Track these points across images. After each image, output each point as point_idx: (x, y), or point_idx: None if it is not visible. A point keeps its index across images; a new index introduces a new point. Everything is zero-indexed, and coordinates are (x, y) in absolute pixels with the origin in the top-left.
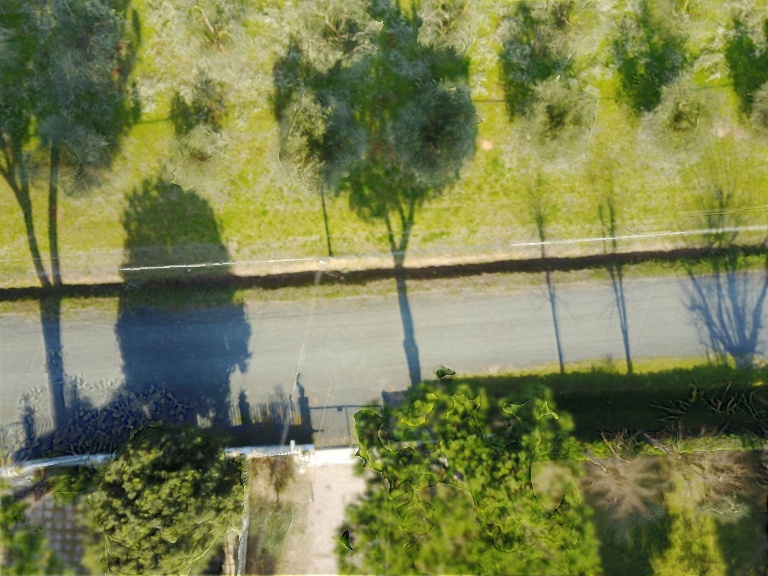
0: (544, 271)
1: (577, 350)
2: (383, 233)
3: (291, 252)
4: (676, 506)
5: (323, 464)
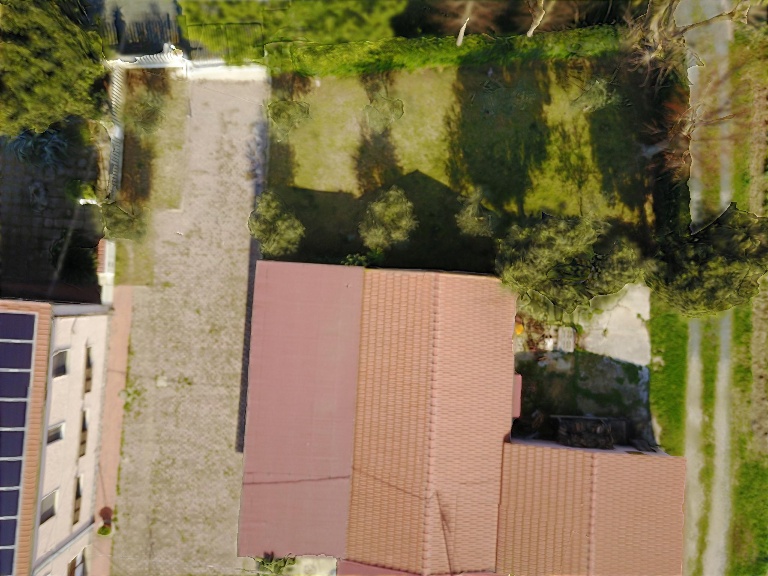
0: None
1: None
2: None
3: None
4: (555, 118)
5: (201, 81)
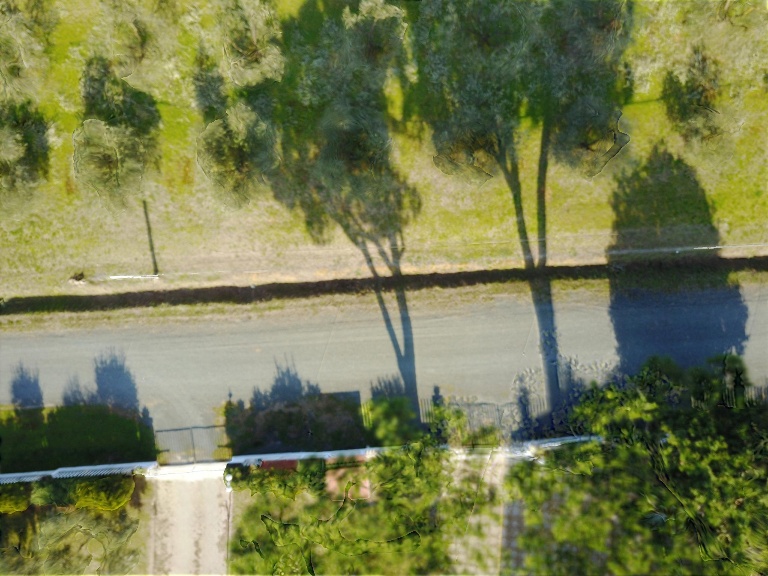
0: None
1: None
2: None
3: None
4: None
5: None
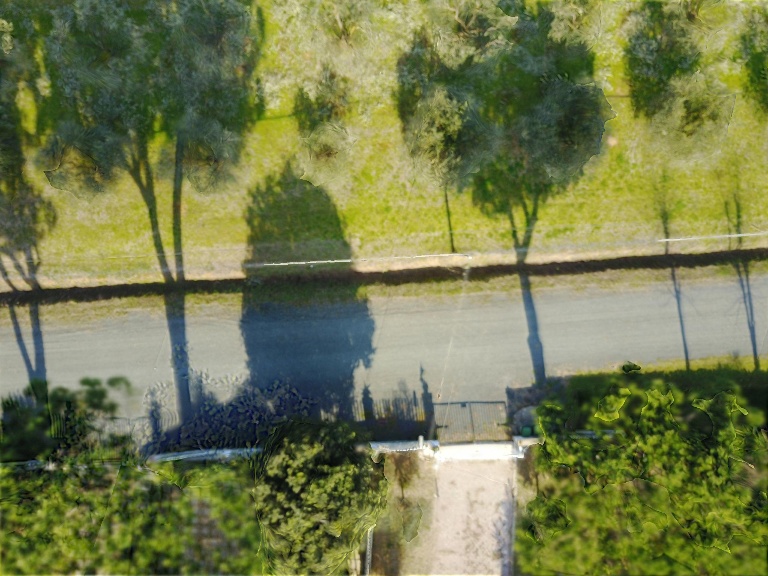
0: (669, 267)
1: (703, 347)
2: (506, 229)
3: (414, 248)
4: None
5: (447, 460)
